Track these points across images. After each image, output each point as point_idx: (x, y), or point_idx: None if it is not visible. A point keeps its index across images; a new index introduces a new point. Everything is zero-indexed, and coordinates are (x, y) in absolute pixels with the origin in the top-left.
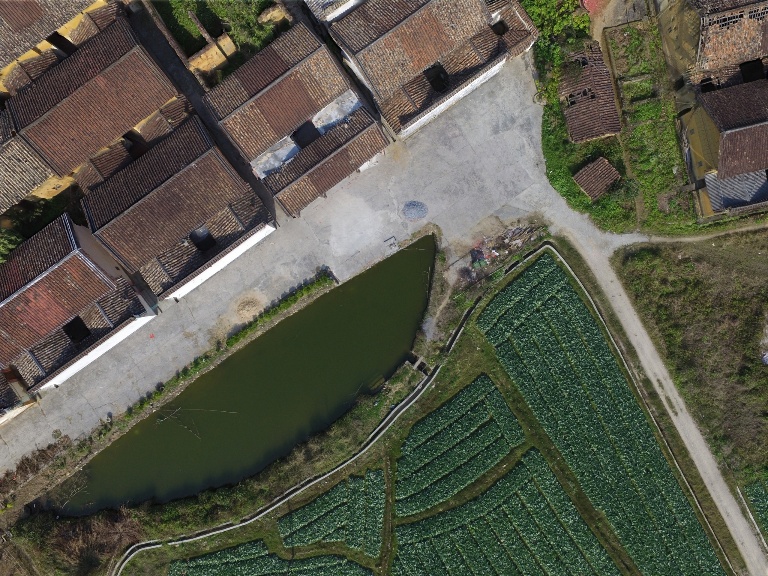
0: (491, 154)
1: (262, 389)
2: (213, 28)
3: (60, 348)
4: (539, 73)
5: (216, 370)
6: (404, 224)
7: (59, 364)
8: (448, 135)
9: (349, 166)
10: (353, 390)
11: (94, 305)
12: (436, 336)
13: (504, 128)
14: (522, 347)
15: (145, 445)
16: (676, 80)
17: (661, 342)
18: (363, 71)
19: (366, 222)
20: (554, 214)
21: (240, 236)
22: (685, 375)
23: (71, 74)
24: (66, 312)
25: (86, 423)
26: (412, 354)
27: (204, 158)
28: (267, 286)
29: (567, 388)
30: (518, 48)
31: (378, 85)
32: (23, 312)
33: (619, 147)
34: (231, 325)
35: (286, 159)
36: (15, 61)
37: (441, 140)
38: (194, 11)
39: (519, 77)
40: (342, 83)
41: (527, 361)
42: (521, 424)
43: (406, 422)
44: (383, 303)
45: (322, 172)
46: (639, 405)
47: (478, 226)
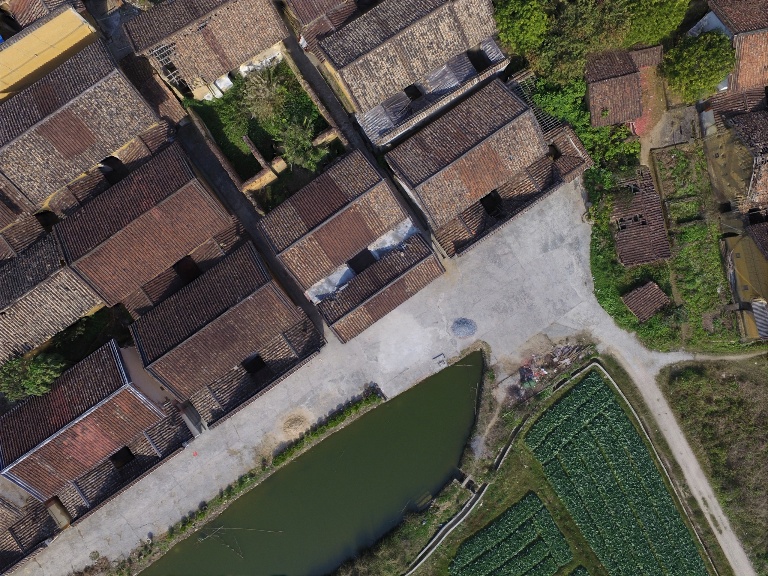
0: (540, 272)
1: (307, 506)
2: (264, 145)
3: (104, 475)
4: (588, 193)
5: (260, 487)
6: (453, 341)
7: (103, 493)
8: (498, 252)
9: (405, 294)
10: (400, 507)
11: (141, 434)
12: (484, 454)
13: (553, 246)
14: (570, 466)
15: (186, 565)
16: (722, 203)
17: (706, 461)
18: (422, 203)
19: (415, 339)
20: (602, 332)
21: (294, 364)
22: (730, 495)
23: (123, 202)
24: (113, 443)
25: (125, 544)
26: (459, 471)
27: (261, 291)
28: (314, 403)
29: (614, 507)
30: (572, 175)
31: (435, 214)
32: (69, 446)
33: (667, 270)
34: (277, 443)
35: (340, 284)
36: (64, 185)
37: (491, 257)
38: (246, 130)
39: (568, 196)
40: (400, 213)
41: (575, 479)
42: (568, 542)
43: (454, 541)
44: (430, 419)
45: (378, 301)
46: (684, 523)
47: (527, 344)
